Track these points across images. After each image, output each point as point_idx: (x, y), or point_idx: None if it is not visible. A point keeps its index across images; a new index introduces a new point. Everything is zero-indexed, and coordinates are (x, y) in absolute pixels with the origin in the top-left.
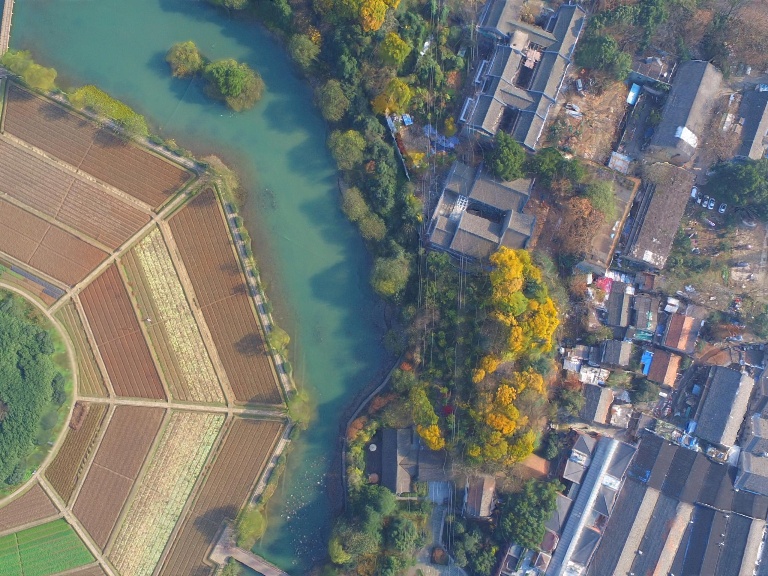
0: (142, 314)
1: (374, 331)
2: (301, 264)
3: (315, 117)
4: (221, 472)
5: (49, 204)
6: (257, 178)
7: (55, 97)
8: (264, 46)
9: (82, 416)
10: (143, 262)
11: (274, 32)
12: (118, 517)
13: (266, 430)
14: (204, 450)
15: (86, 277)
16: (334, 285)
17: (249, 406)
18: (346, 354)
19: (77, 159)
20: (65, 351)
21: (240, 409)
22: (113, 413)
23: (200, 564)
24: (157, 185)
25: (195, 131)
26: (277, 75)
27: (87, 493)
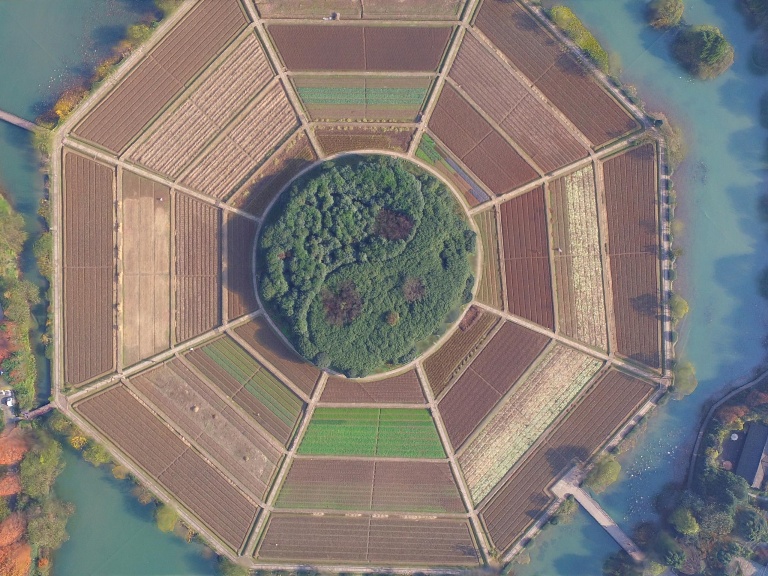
0: (554, 242)
1: (762, 329)
2: (712, 244)
3: (760, 107)
4: (584, 414)
5: (497, 109)
6: (696, 148)
7: (532, 8)
8: (740, 23)
9: (474, 320)
10: (569, 194)
11: (755, 13)
12: (478, 424)
13: (637, 388)
14: (575, 388)
15: (512, 190)
16: (737, 274)
17: (628, 361)
18: (728, 342)
19: (535, 75)
20: (475, 254)
21: (619, 361)
22: (501, 327)
23: (540, 492)
24: (603, 124)
25: (651, 84)
26: (743, 56)
27: (456, 393)
